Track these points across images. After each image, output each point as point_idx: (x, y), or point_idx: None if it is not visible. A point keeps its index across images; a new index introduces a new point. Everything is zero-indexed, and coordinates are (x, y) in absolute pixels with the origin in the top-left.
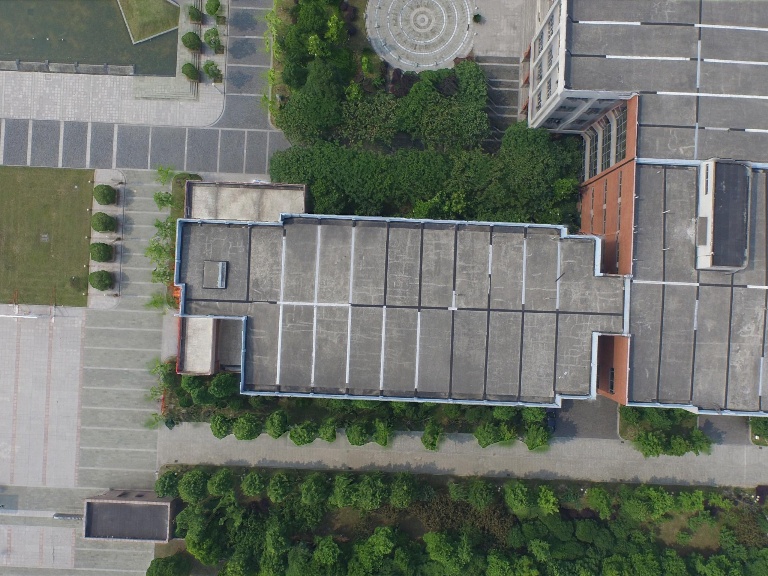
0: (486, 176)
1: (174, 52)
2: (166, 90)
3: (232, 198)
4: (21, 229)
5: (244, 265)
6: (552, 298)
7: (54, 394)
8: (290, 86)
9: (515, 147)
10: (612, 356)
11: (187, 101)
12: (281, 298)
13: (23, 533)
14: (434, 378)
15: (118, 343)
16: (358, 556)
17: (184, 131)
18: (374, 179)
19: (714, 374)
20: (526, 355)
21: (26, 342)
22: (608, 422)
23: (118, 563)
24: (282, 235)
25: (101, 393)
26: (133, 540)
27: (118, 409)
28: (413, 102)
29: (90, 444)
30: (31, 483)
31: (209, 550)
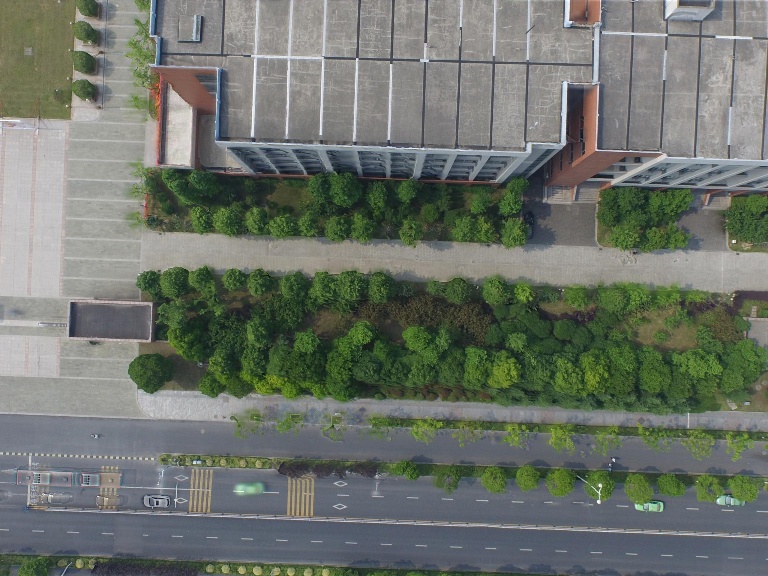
0: None
1: None
2: None
3: None
4: (5, 43)
5: (219, 20)
6: (522, 50)
7: (39, 205)
8: None
9: None
10: (582, 104)
11: None
12: (255, 51)
13: (9, 342)
14: (406, 129)
15: (101, 155)
16: (338, 349)
17: None
18: None
19: (683, 124)
20: (497, 106)
21: (11, 154)
22: (586, 229)
23: (103, 372)
24: None
25: (85, 204)
26: (116, 339)
27: (102, 220)
28: None
29: (74, 254)
30: (16, 293)
31: (191, 345)
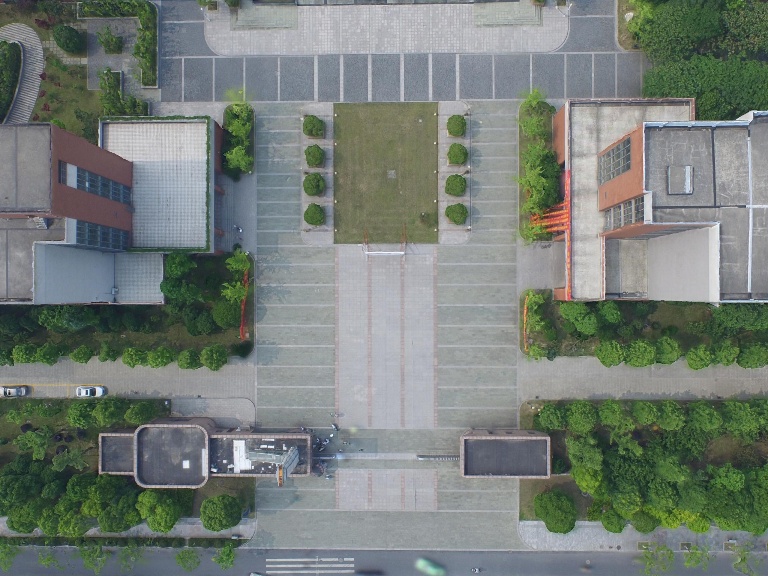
0: None
1: None
2: (510, 16)
3: (613, 117)
4: (367, 167)
5: (709, 169)
6: None
7: (409, 334)
8: (646, 3)
9: None
10: None
11: (530, 26)
12: (750, 201)
13: (384, 477)
14: None
15: (472, 279)
16: (758, 483)
17: (528, 58)
18: (764, 89)
19: None
20: None
21: (377, 282)
22: None
23: (482, 504)
24: (746, 136)
25: (457, 331)
26: (514, 476)
27: (475, 346)
28: None
29: (448, 383)
30: (390, 425)
31: (600, 483)
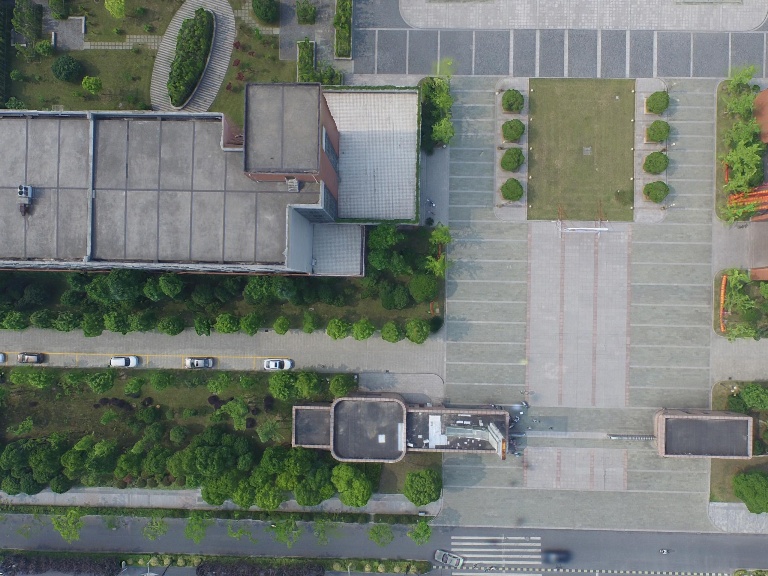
0: None
1: None
2: None
3: None
4: (562, 143)
5: None
6: None
7: (601, 312)
8: None
9: None
10: None
11: (731, 4)
12: None
13: (573, 455)
14: None
15: (666, 258)
16: None
17: (727, 36)
18: None
19: None
20: None
21: (571, 259)
22: None
23: (672, 484)
24: None
25: (650, 310)
26: (715, 456)
27: (668, 326)
28: None
29: (640, 363)
30: (580, 404)
31: None
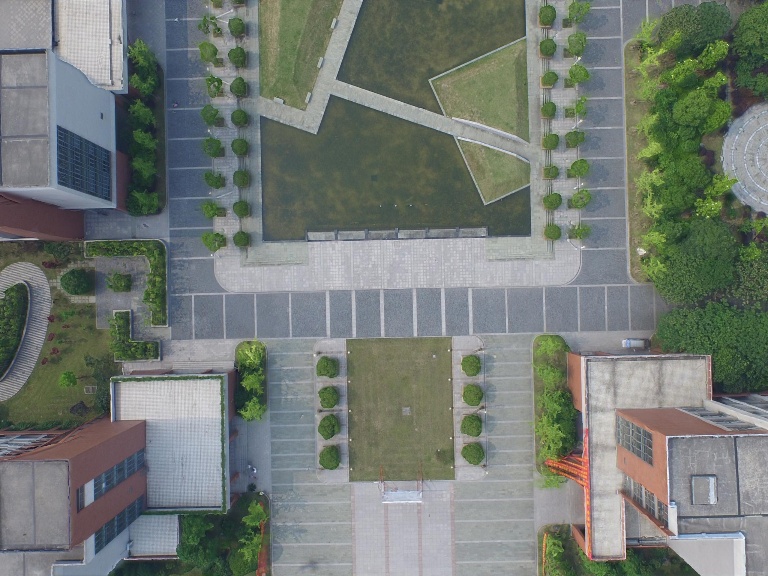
0: None
1: (526, 210)
2: (522, 250)
3: (630, 372)
4: (381, 404)
5: (732, 477)
6: None
7: (427, 571)
8: None
9: None
10: None
11: (543, 260)
12: None
13: None
14: None
15: (489, 515)
16: None
17: (541, 291)
18: None
19: None
20: None
21: (394, 519)
22: None
23: None
24: None
25: (475, 567)
26: None
27: None
28: None
29: None
30: None
31: None
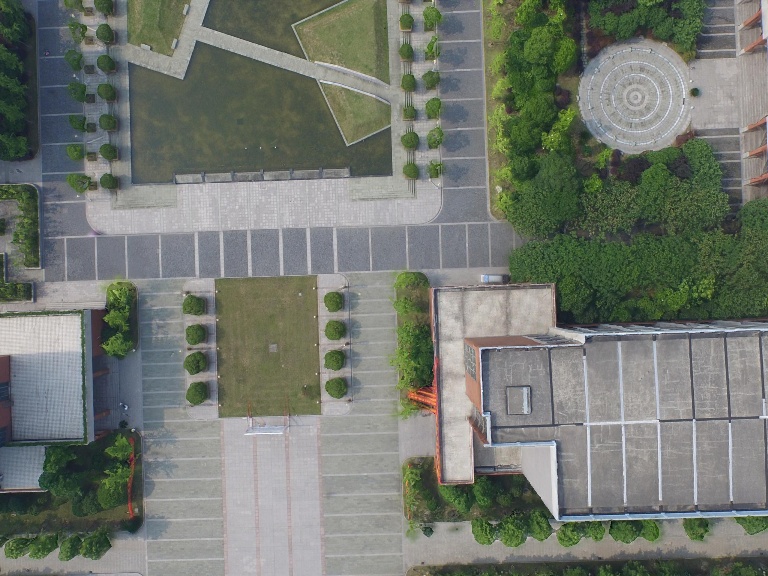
0: (736, 260)
1: (388, 151)
2: (384, 190)
3: (478, 301)
4: (249, 341)
5: (546, 388)
6: None
7: (295, 504)
8: (514, 178)
9: (761, 227)
10: None
11: (405, 199)
12: (587, 419)
13: None
14: (750, 489)
15: (355, 448)
16: None
17: (403, 229)
18: (622, 272)
19: None
20: None
21: (263, 454)
22: None
23: None
24: (582, 355)
25: (342, 500)
26: None
27: (360, 515)
28: (652, 189)
29: (335, 552)
30: None
31: None
